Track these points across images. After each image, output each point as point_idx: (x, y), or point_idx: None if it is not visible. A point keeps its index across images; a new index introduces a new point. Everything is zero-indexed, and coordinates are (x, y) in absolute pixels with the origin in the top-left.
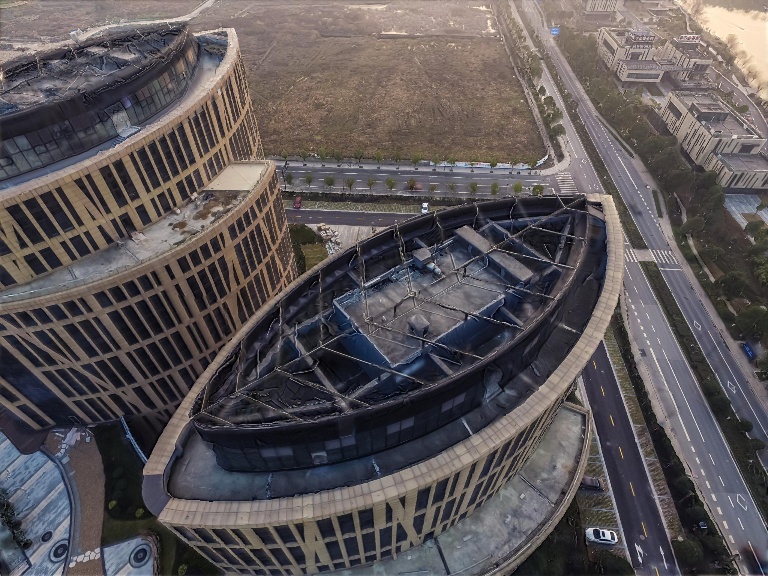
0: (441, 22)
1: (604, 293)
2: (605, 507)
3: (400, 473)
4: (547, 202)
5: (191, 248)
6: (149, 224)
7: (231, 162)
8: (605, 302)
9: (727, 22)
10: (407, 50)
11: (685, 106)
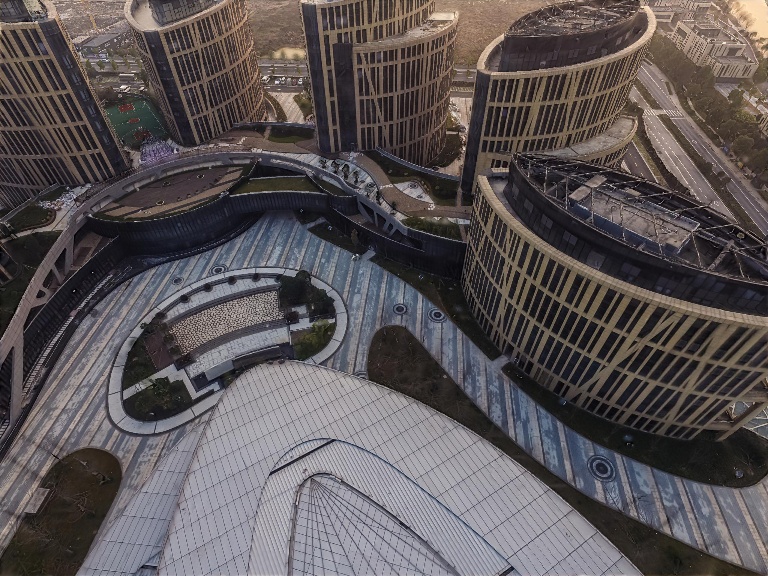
0: None
1: (648, 29)
2: None
3: None
4: None
5: (437, 36)
6: (411, 29)
7: (434, 11)
8: (649, 31)
9: None
10: (468, 4)
11: (689, 28)
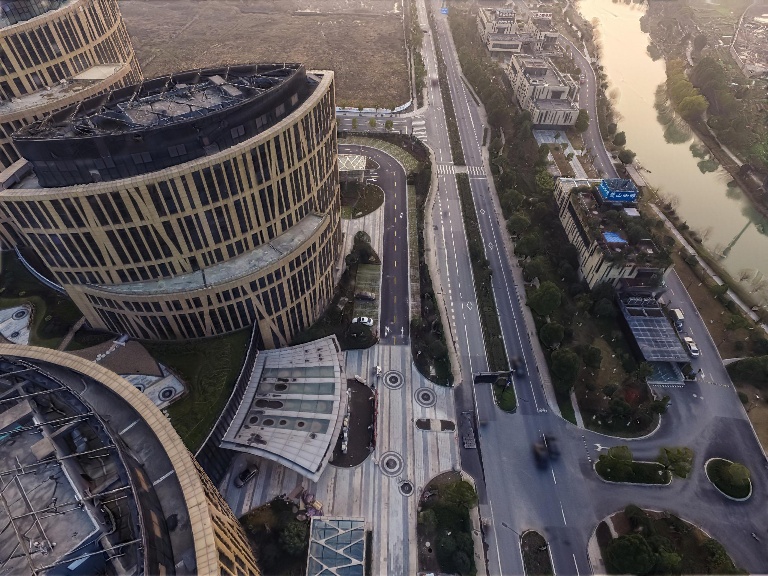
0: (353, 3)
1: (295, 112)
2: (372, 309)
3: (136, 177)
4: (279, 68)
5: (53, 107)
6: (25, 94)
7: (96, 64)
8: (293, 115)
9: (603, 10)
10: (316, 25)
11: (519, 64)
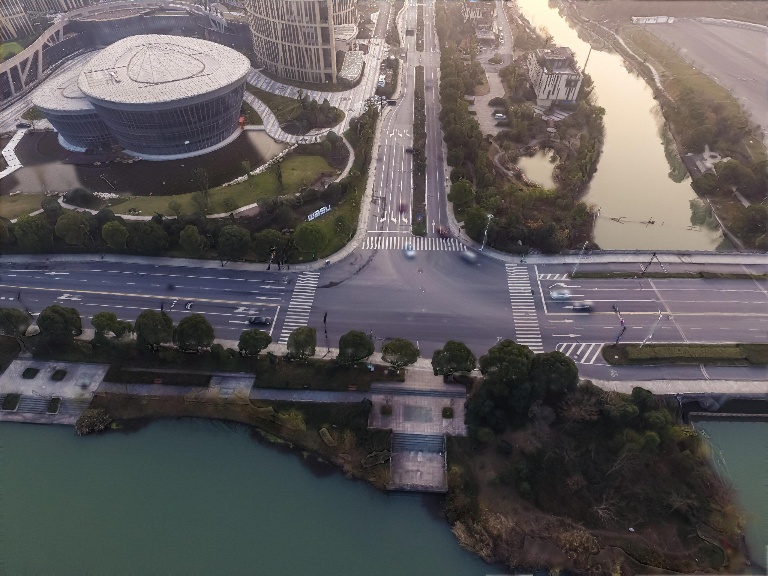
0: None
1: None
2: None
3: None
4: None
5: None
6: None
7: None
8: None
9: None
10: None
11: None
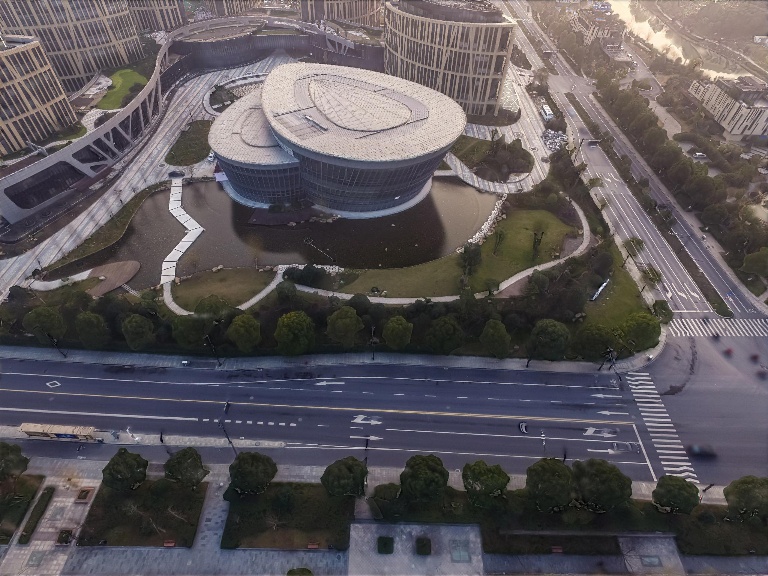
0: None
1: None
2: None
3: None
4: None
5: None
6: None
7: None
8: None
9: None
10: None
11: None
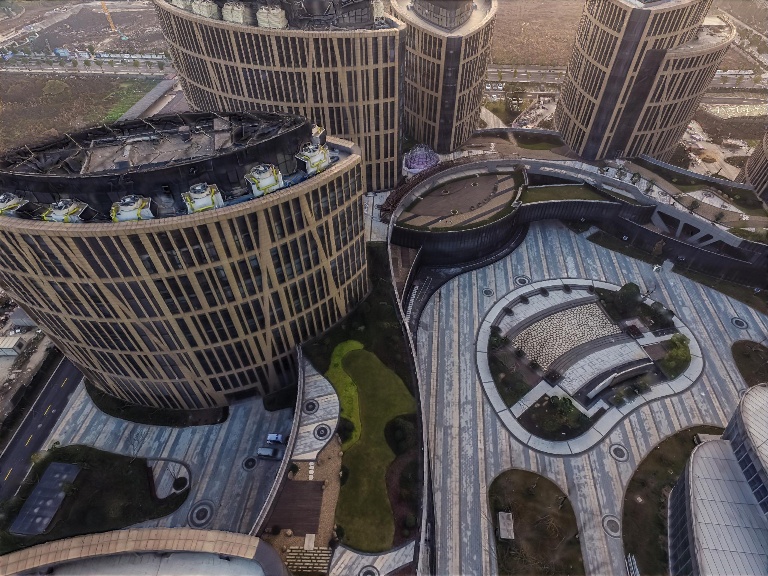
0: None
1: None
2: None
3: None
4: None
5: None
6: (697, 34)
7: None
8: None
9: None
10: None
11: None
